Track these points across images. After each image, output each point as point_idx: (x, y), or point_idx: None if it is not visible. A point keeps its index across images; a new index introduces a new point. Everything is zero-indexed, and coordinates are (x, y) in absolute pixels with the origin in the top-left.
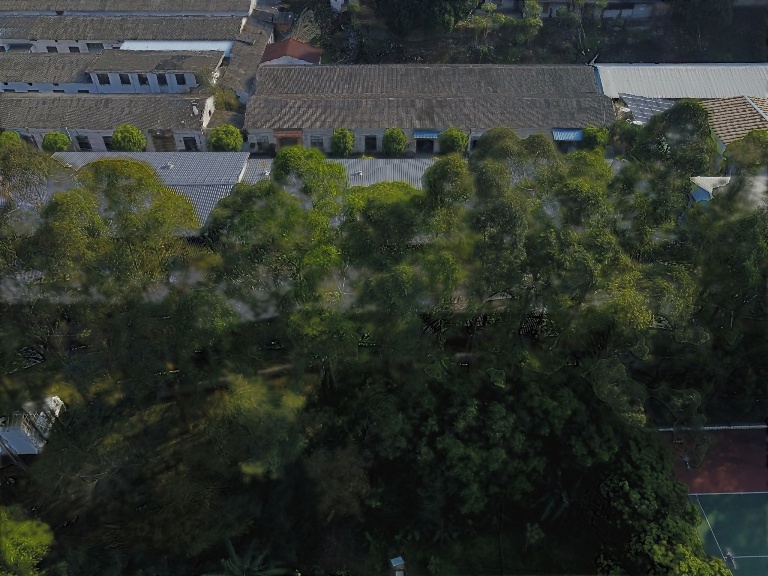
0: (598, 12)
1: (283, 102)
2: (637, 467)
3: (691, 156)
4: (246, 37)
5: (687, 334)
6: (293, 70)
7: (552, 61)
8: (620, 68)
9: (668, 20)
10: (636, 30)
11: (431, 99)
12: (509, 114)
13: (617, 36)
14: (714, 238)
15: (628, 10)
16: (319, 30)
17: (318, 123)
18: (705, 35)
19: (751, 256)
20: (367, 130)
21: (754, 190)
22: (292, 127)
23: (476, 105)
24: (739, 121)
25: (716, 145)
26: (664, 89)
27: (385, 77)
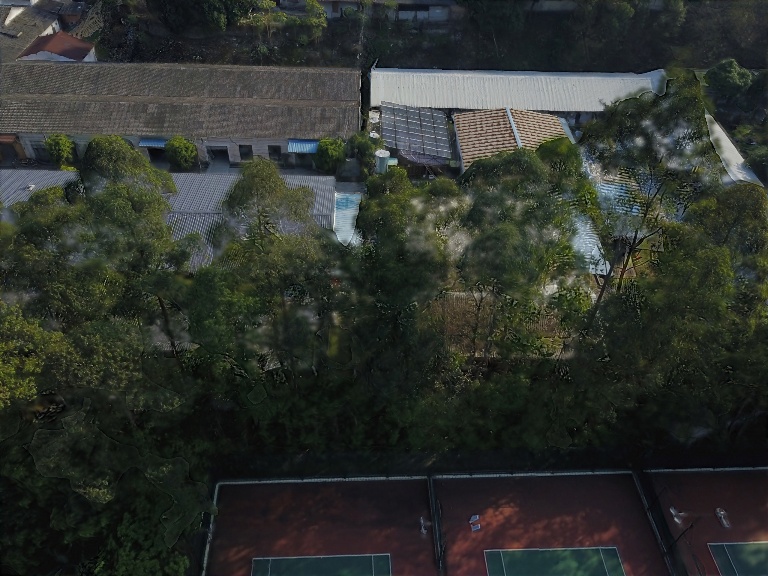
0: (391, 13)
1: (2, 103)
2: (120, 544)
3: (106, 201)
4: (10, 29)
5: (141, 401)
6: (36, 67)
7: (340, 64)
8: (394, 74)
9: (467, 24)
10: (434, 33)
11: (166, 104)
12: (246, 122)
13: (412, 39)
14: (182, 291)
15: (423, 12)
16: (102, 23)
17: (35, 128)
18: (504, 41)
19: (218, 313)
20: (89, 136)
21: (225, 237)
22: (5, 131)
23: (213, 112)
24: (488, 136)
25: (461, 161)
26: (435, 98)
27: (135, 78)
